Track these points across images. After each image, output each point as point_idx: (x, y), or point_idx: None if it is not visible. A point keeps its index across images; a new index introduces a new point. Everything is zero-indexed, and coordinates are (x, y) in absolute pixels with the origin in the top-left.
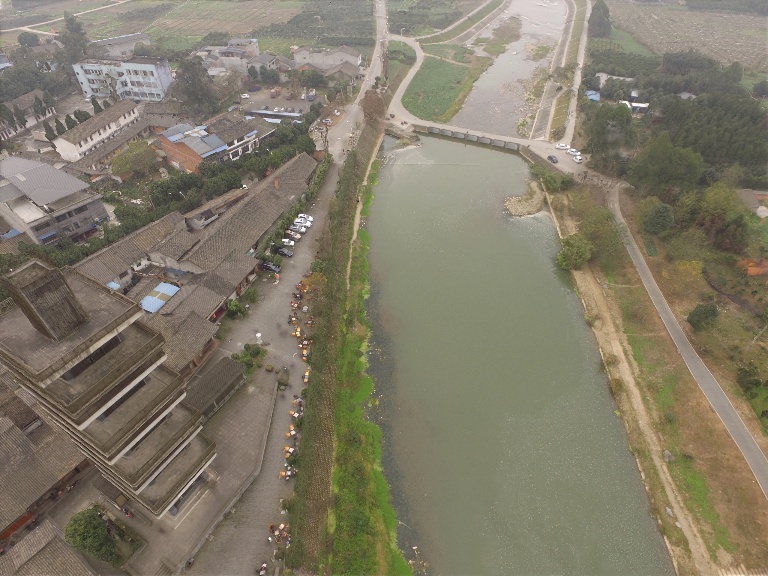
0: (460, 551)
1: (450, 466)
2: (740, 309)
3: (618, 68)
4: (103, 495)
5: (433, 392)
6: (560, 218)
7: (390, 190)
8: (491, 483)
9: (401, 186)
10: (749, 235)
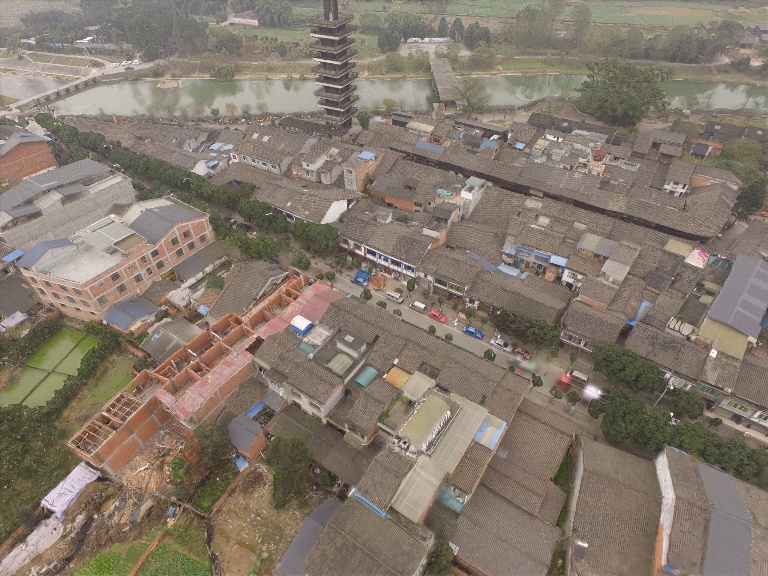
0: (360, 103)
1: None
2: (275, 52)
3: (26, 32)
4: None
5: None
6: (188, 77)
7: None
8: None
9: (116, 113)
10: (239, 38)
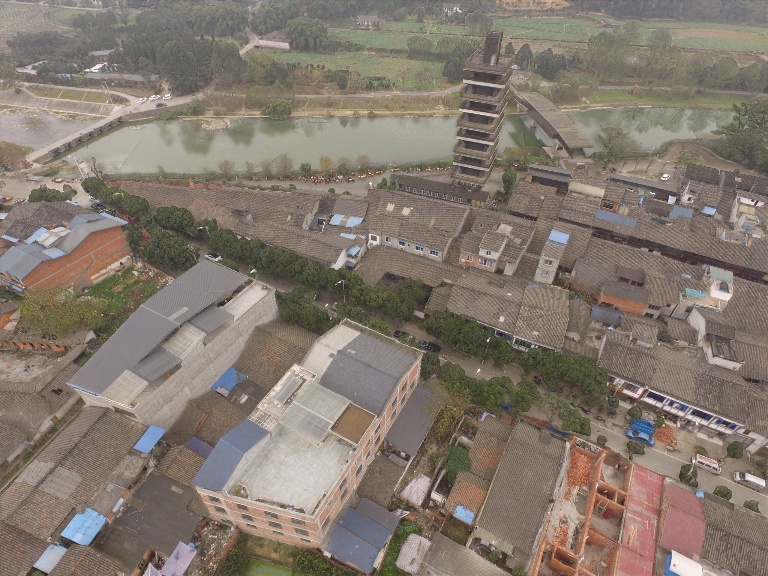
0: None
1: (422, 149)
2: (327, 83)
3: (20, 59)
4: (485, 207)
5: (385, 152)
6: (235, 114)
7: (170, 171)
8: (426, 141)
9: (166, 166)
10: (283, 66)
